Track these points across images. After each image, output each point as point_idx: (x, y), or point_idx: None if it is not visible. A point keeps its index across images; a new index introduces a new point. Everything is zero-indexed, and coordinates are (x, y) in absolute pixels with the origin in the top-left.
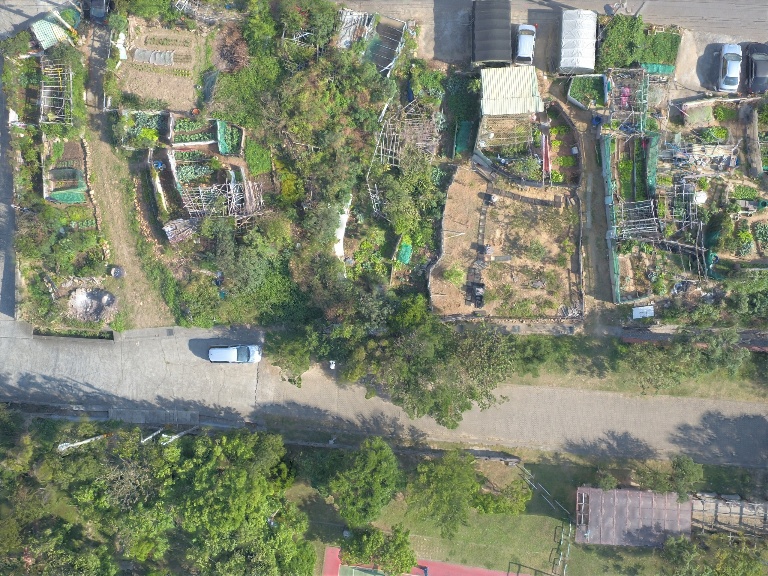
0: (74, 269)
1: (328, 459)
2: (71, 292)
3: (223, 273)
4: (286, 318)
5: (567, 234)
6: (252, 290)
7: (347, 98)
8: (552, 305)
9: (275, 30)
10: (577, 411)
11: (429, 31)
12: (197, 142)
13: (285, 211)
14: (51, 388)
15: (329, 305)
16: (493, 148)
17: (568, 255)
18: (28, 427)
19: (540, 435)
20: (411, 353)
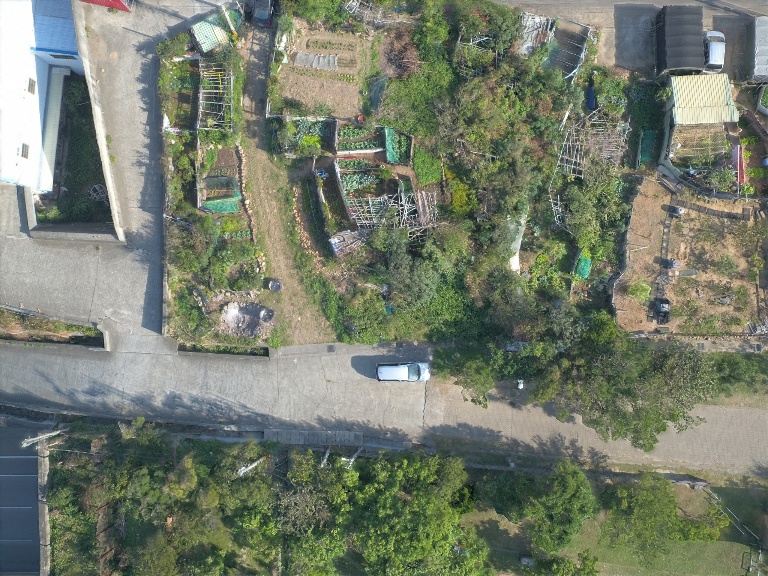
0: (229, 282)
1: (518, 484)
2: (223, 306)
3: (390, 287)
4: (458, 334)
5: (755, 248)
6: (422, 305)
7: (528, 105)
8: (740, 322)
9: (448, 34)
10: (766, 432)
11: (610, 37)
12: (364, 150)
13: (462, 223)
14: (198, 407)
15: (511, 321)
16: (679, 158)
17: (756, 270)
18: (176, 448)
19: (727, 457)
20: (612, 373)
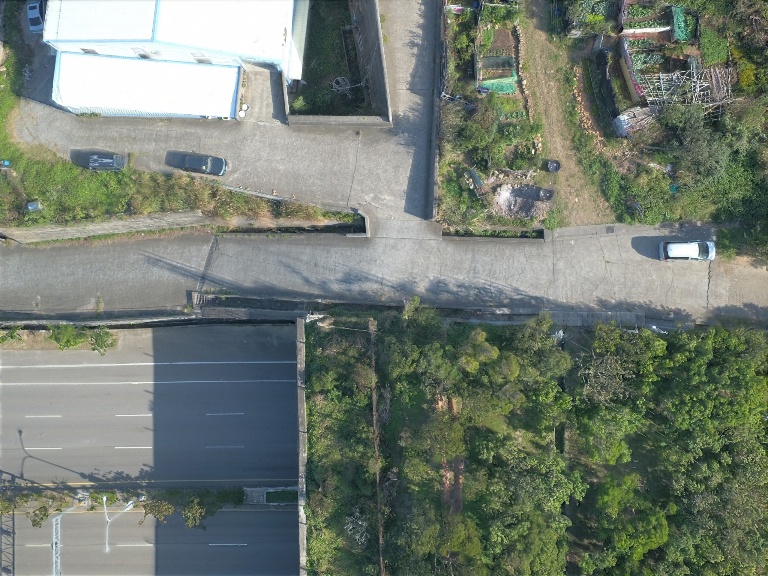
0: (506, 162)
1: None
2: (496, 188)
3: (676, 166)
4: (746, 213)
5: None
6: (709, 184)
7: None
8: None
9: None
10: None
11: None
12: (651, 28)
13: (758, 98)
14: (464, 292)
15: None
16: None
17: None
18: (446, 331)
19: None
20: None
